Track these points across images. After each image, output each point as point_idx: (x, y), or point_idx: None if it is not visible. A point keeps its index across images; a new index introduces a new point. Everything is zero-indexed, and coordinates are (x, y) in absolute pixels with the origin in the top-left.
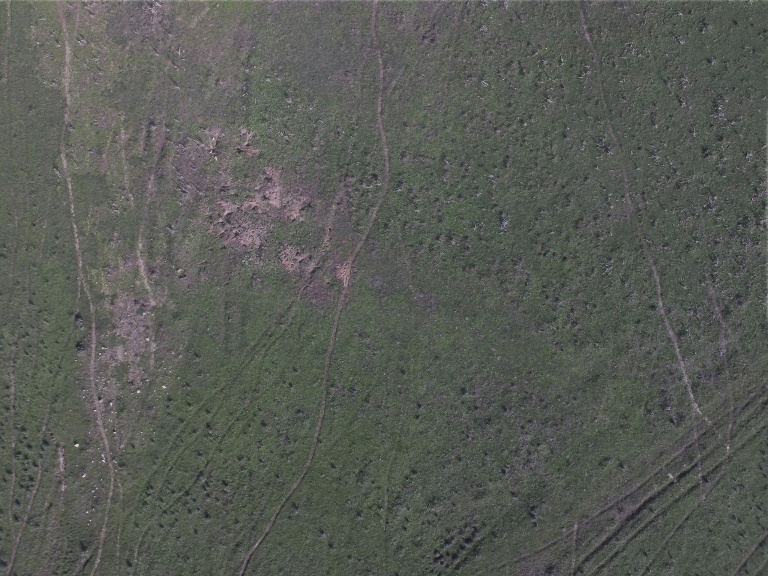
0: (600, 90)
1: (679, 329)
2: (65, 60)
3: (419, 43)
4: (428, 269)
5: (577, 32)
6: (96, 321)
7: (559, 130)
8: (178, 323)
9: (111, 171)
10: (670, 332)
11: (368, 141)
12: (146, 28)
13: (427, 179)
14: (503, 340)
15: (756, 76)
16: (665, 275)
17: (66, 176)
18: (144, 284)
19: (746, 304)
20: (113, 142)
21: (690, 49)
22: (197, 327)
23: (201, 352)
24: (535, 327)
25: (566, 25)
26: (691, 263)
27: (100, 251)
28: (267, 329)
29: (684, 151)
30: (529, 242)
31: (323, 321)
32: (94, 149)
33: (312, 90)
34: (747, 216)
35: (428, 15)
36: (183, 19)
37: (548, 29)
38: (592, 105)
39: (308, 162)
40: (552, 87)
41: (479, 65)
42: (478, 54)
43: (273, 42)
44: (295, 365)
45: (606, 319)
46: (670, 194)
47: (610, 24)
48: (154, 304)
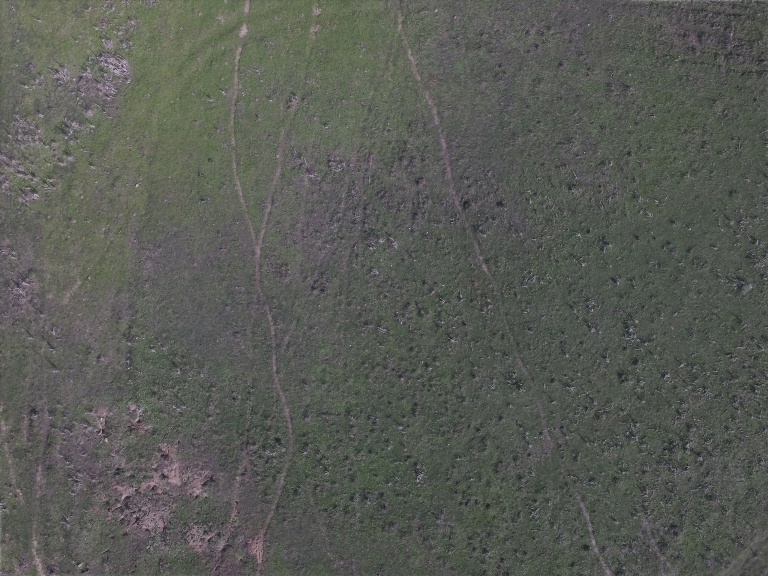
0: (504, 323)
1: (616, 567)
2: None
3: (308, 294)
4: (345, 534)
5: (473, 265)
6: None
7: (466, 370)
8: None
9: None
10: (607, 571)
11: (266, 403)
12: (15, 309)
13: (334, 437)
14: None
15: (665, 291)
16: (594, 512)
17: None
18: None
19: (682, 534)
20: None
21: (593, 270)
22: None
23: None
24: None
25: (461, 259)
26: (620, 495)
27: None
28: None
29: (599, 378)
30: (448, 492)
31: None
32: None
33: (201, 356)
34: (672, 441)
35: (315, 264)
36: (54, 296)
37: (443, 265)
38: (498, 339)
39: (205, 433)
40: (454, 325)
41: (374, 311)
42: (372, 299)
43: (153, 309)
44: None
45: (538, 565)
46: (590, 425)
47: (507, 252)
48: None
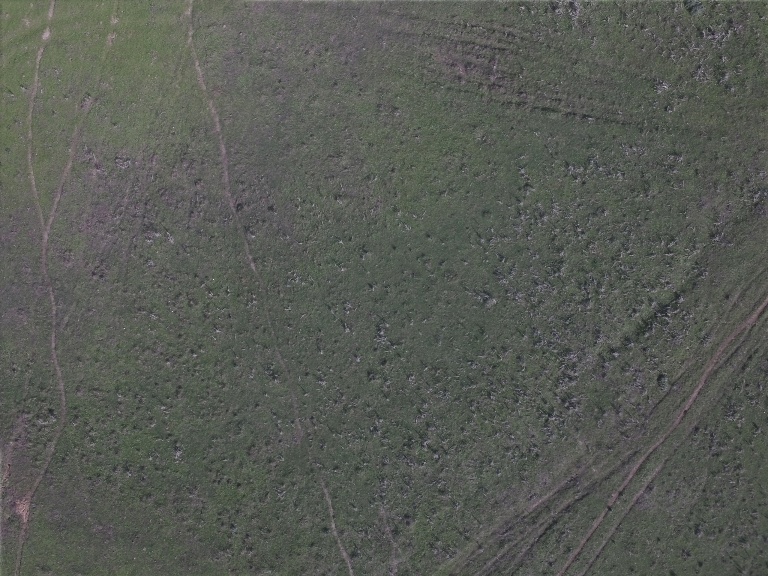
0: (267, 318)
1: (352, 550)
2: None
3: (89, 279)
4: (106, 501)
5: (242, 263)
6: None
7: (229, 359)
8: None
9: None
10: (343, 553)
11: (44, 376)
12: None
13: (103, 412)
14: (180, 569)
15: (417, 299)
16: (336, 498)
17: None
18: None
19: (414, 524)
20: None
21: (352, 275)
22: None
23: None
24: (211, 555)
25: (231, 256)
26: (361, 485)
27: None
28: None
29: (350, 375)
30: (204, 470)
31: (6, 556)
32: None
33: None
34: (411, 438)
35: (97, 251)
36: None
37: (214, 260)
38: (260, 333)
39: None
40: (220, 317)
41: (148, 298)
42: (147, 288)
43: None
44: None
45: (281, 543)
46: (338, 418)
47: (274, 253)
48: None
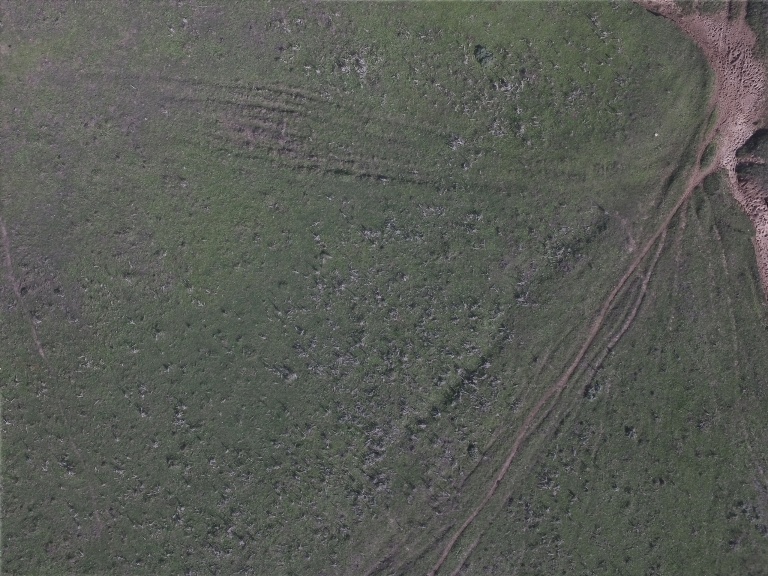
0: (59, 406)
1: None
2: None
3: None
4: None
5: (30, 350)
6: None
7: (21, 451)
8: None
9: None
10: None
11: None
12: None
13: None
14: None
15: (215, 378)
16: None
17: None
18: None
19: None
20: None
21: (146, 356)
22: None
23: None
24: None
25: (18, 344)
26: None
27: None
28: None
29: (149, 462)
30: None
31: None
32: None
33: None
34: (215, 525)
35: None
36: None
37: (0, 349)
38: (53, 422)
39: None
40: (10, 408)
41: None
42: None
43: None
44: None
45: None
46: (139, 507)
47: (63, 338)
48: None
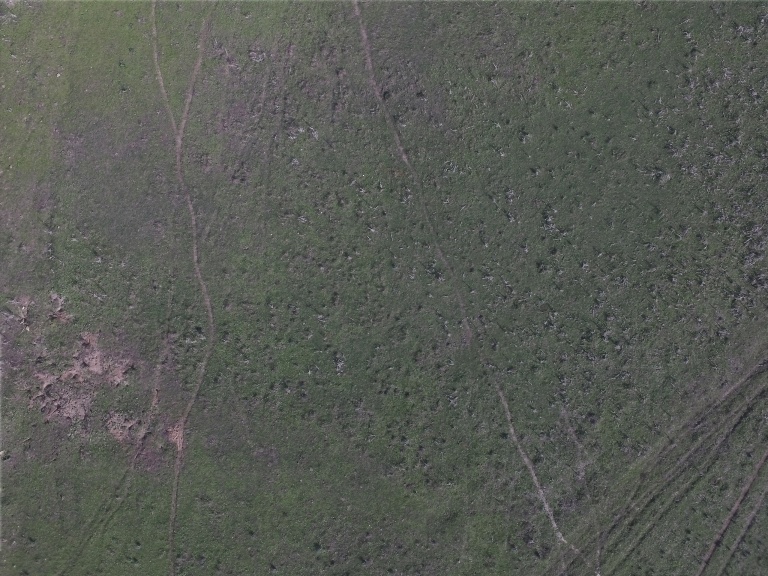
0: (424, 213)
1: (534, 455)
2: None
3: (229, 184)
4: (265, 421)
5: (393, 155)
6: None
7: (386, 259)
8: (7, 508)
9: None
10: (525, 459)
11: (187, 293)
12: None
13: (254, 326)
14: (351, 488)
15: (584, 181)
16: (513, 400)
17: None
18: None
19: (599, 422)
20: None
21: (513, 160)
22: (29, 509)
23: (36, 535)
24: (383, 470)
25: (381, 149)
26: (538, 384)
27: None
28: (103, 503)
29: (518, 268)
30: (368, 381)
31: (161, 488)
32: None
33: (122, 245)
34: (590, 329)
35: (235, 154)
36: None
37: (363, 155)
38: (418, 230)
39: (126, 322)
40: (374, 215)
41: (295, 200)
42: (292, 189)
43: (75, 199)
44: (137, 538)
45: (457, 453)
46: (509, 314)
47: (427, 143)
48: None
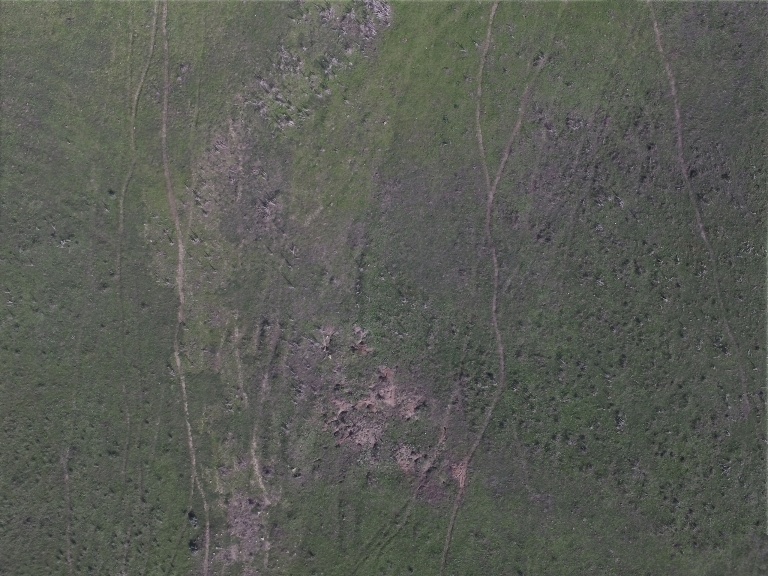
0: (716, 289)
1: None
2: (178, 258)
3: (534, 242)
4: (545, 469)
5: (693, 231)
6: (210, 519)
7: (675, 329)
8: (293, 522)
9: (225, 370)
10: None
11: (483, 339)
12: (259, 226)
13: (542, 378)
14: (621, 541)
15: None
16: None
17: (180, 374)
18: (259, 483)
19: None
20: (227, 341)
21: None
22: (311, 525)
23: (315, 550)
24: (653, 529)
25: (682, 224)
26: None
27: (214, 450)
28: (382, 528)
29: None
30: (646, 442)
31: (439, 520)
32: (208, 347)
33: (426, 288)
34: None
35: (543, 214)
36: (297, 218)
37: (664, 228)
38: (708, 304)
39: (423, 361)
40: (668, 286)
41: (594, 264)
42: (593, 253)
43: (387, 240)
44: (410, 564)
45: (724, 520)
46: None
47: (726, 223)
48: (269, 503)
